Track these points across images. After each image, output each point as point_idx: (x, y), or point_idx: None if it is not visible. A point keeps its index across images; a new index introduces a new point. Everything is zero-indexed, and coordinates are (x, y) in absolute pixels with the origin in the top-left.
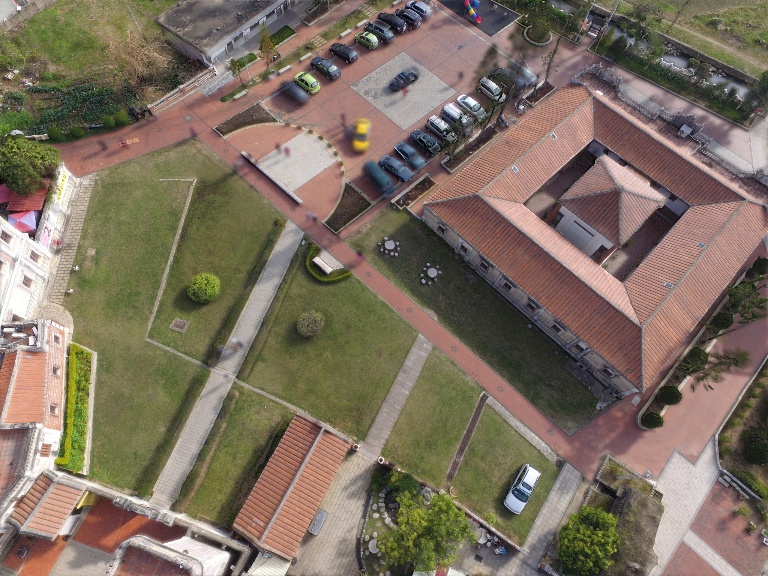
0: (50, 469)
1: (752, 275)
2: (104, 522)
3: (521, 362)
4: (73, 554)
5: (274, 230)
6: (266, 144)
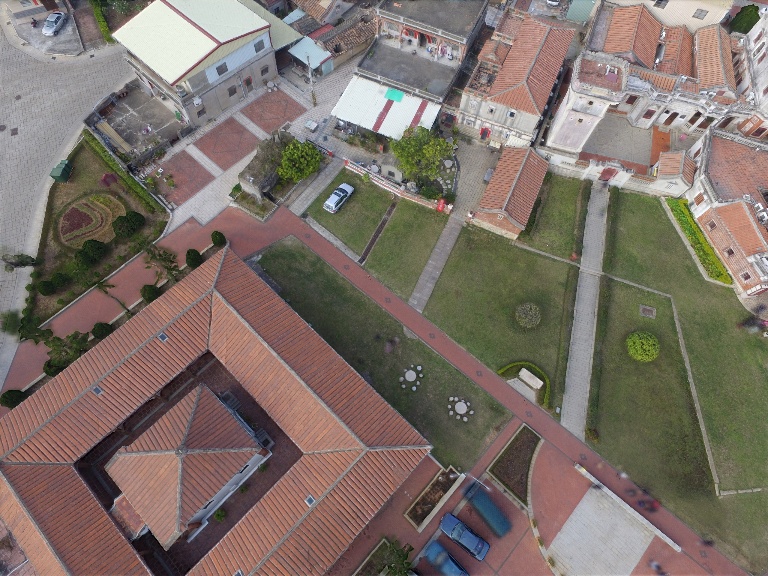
0: (688, 194)
1: (29, 395)
2: None
3: (324, 292)
4: (643, 159)
5: (596, 421)
6: (654, 573)
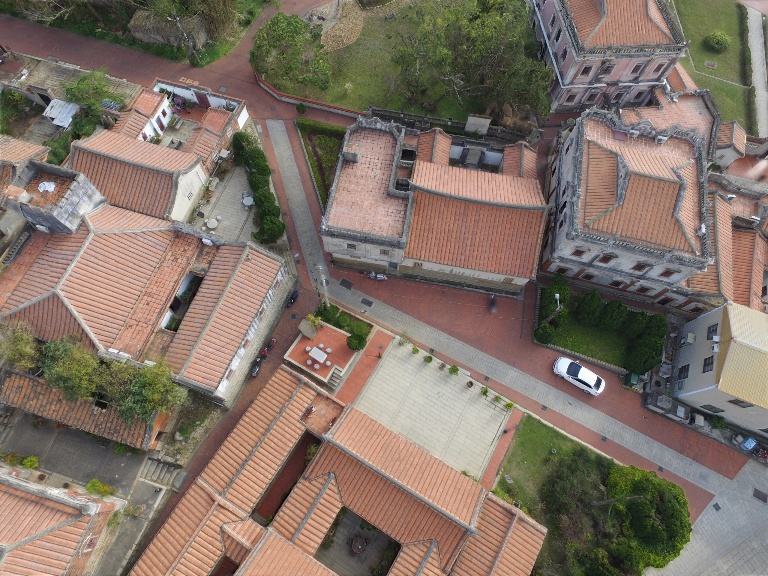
0: None
1: None
2: (740, 165)
3: None
4: None
5: (744, 9)
6: None
